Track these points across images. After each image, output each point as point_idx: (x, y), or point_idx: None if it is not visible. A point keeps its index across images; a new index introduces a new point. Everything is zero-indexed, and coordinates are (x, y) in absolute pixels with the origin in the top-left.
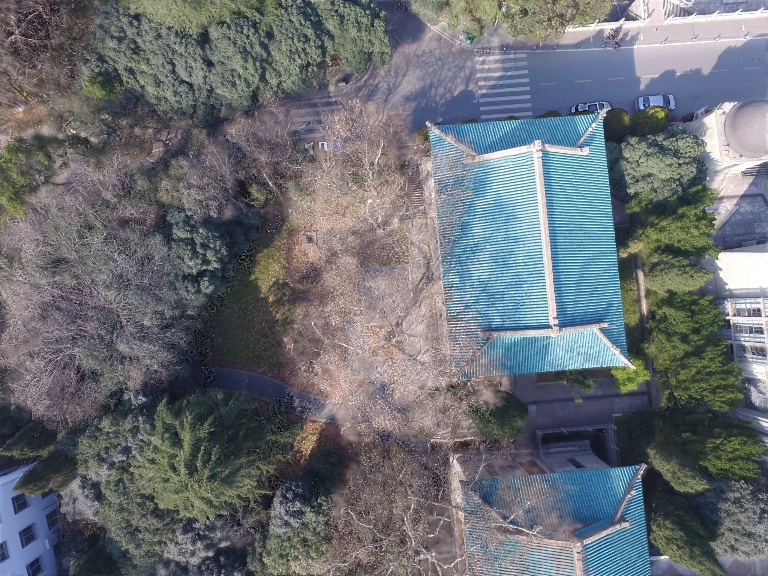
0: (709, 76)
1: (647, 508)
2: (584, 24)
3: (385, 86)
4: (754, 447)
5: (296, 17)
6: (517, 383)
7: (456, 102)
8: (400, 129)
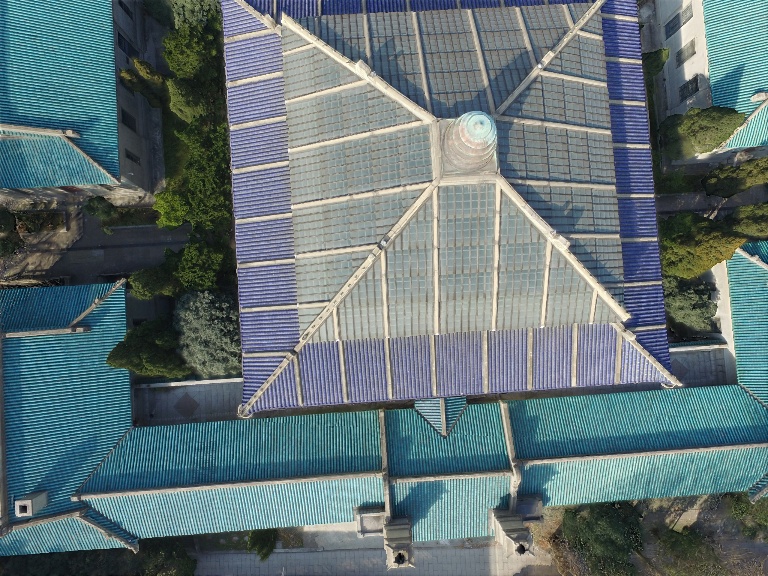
0: None
1: None
2: None
3: None
4: (216, 257)
5: None
6: (86, 228)
7: None
8: None
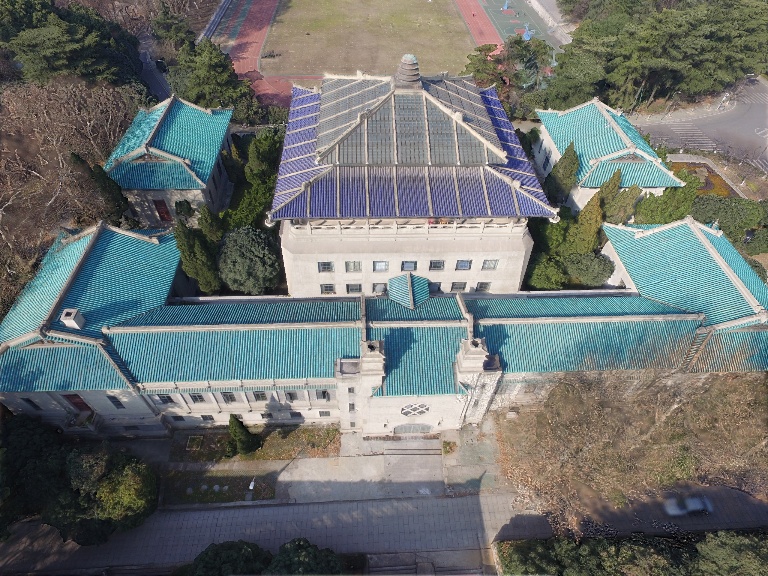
0: None
1: None
2: (278, 123)
3: None
4: None
5: (105, 91)
6: None
7: None
8: None
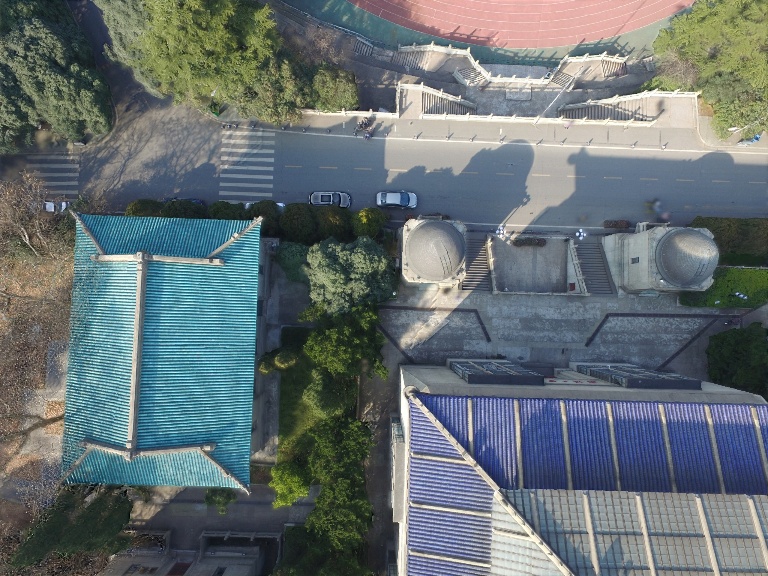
0: (459, 177)
1: None
2: (332, 110)
3: (126, 150)
4: None
5: None
6: None
7: (196, 174)
8: (101, 203)
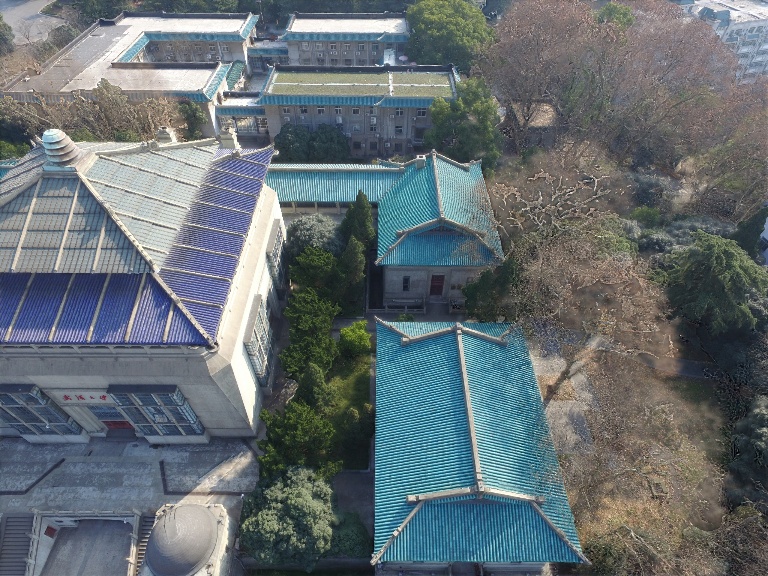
0: None
1: (369, 249)
2: None
3: None
4: None
5: None
6: None
7: None
8: None
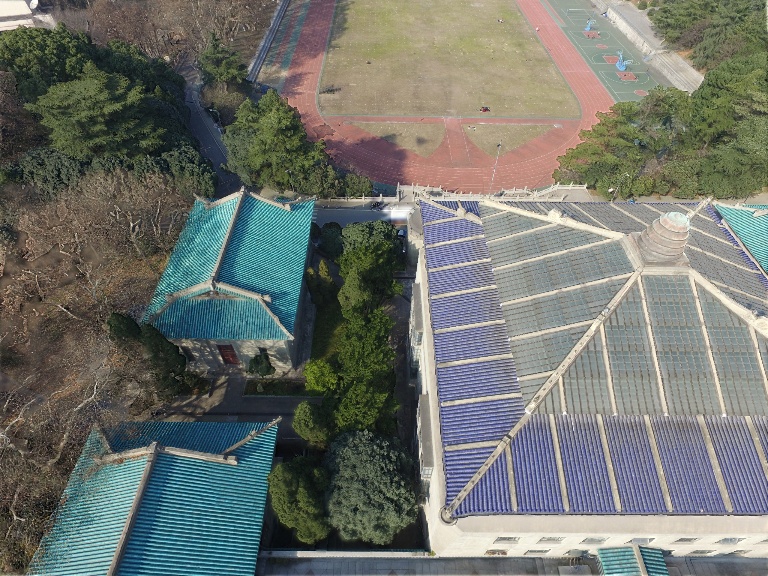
0: None
1: None
2: (356, 196)
3: None
4: (379, 397)
5: (150, 161)
6: (227, 395)
7: None
8: None
